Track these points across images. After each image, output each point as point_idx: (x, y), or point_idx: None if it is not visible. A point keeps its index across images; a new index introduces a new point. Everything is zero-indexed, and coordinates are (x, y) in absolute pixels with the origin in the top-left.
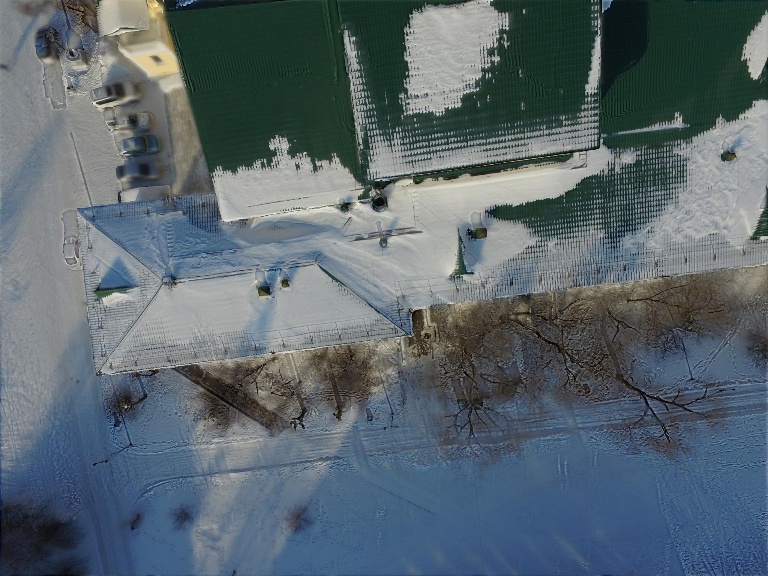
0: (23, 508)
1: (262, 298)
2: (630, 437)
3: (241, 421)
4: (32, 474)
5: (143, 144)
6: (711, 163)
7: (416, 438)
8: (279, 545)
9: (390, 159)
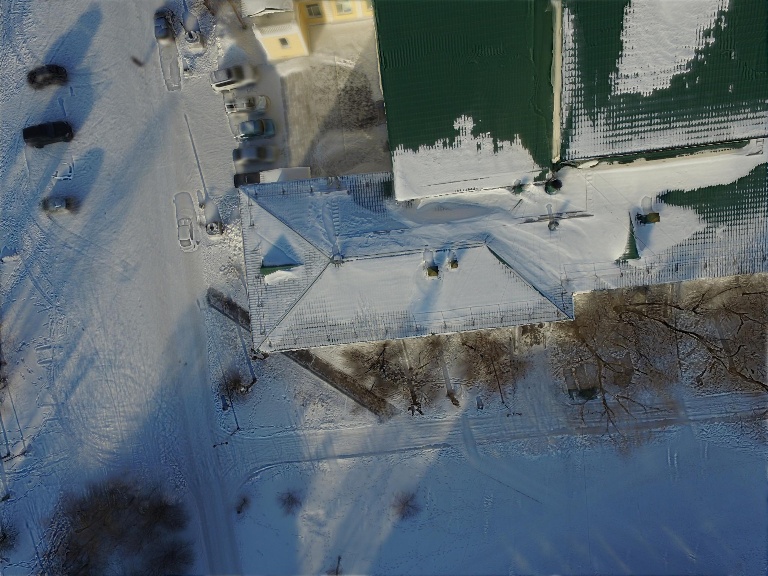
0: (129, 490)
1: (428, 279)
2: (741, 430)
3: (350, 407)
4: (137, 456)
5: (261, 127)
6: None
7: (526, 427)
8: (385, 532)
9: (591, 139)
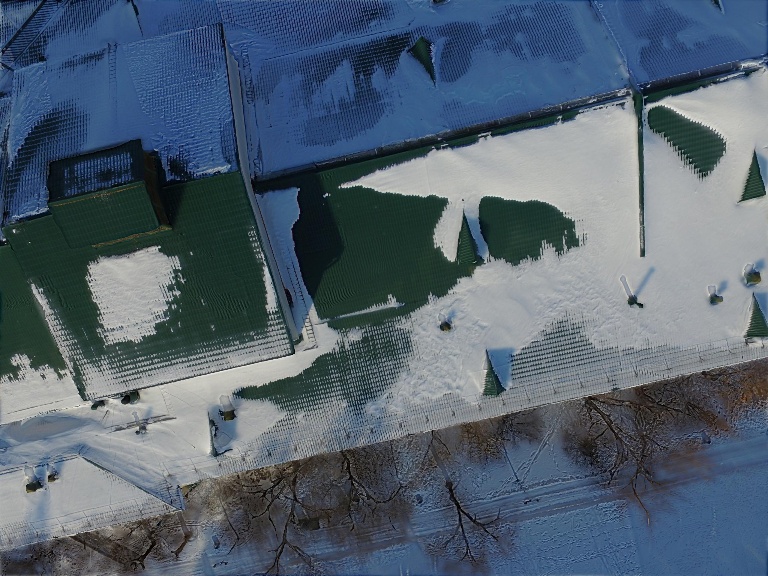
0: None
1: None
2: None
3: (95, 558)
4: None
5: None
6: (432, 334)
7: (263, 560)
8: None
9: (103, 382)
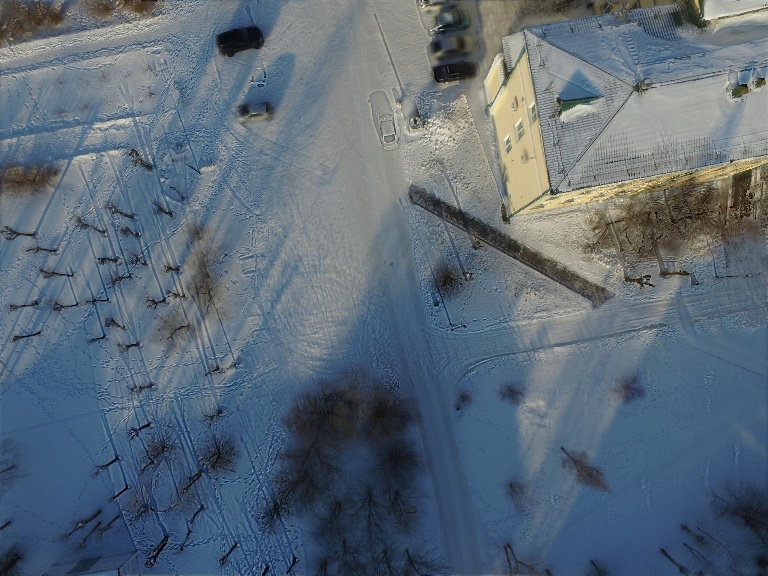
0: (345, 394)
1: (731, 101)
2: None
3: (563, 294)
4: (348, 361)
5: (459, 18)
6: None
7: (741, 301)
8: (607, 418)
9: None
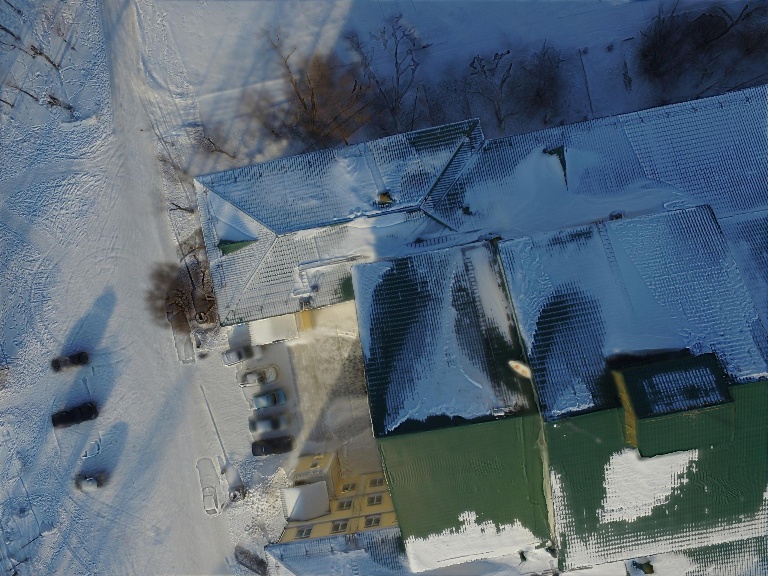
0: None
1: None
2: None
3: None
4: None
5: (273, 400)
6: None
7: None
8: None
9: (585, 555)
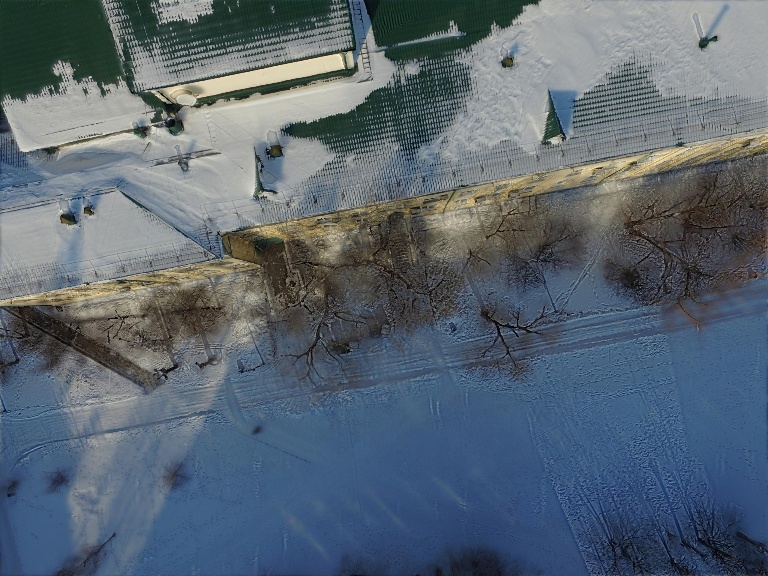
0: None
1: (69, 228)
2: (499, 373)
3: (114, 380)
4: None
5: None
6: (493, 70)
7: (288, 387)
8: (157, 504)
9: (153, 70)
